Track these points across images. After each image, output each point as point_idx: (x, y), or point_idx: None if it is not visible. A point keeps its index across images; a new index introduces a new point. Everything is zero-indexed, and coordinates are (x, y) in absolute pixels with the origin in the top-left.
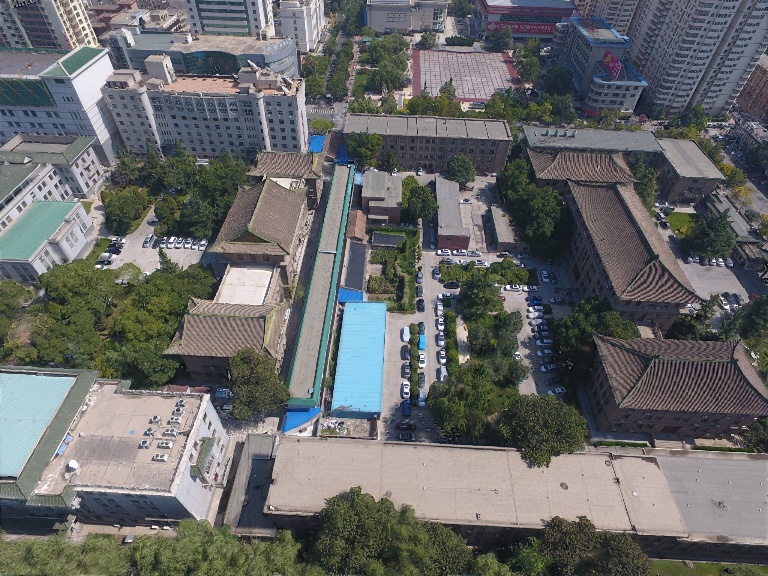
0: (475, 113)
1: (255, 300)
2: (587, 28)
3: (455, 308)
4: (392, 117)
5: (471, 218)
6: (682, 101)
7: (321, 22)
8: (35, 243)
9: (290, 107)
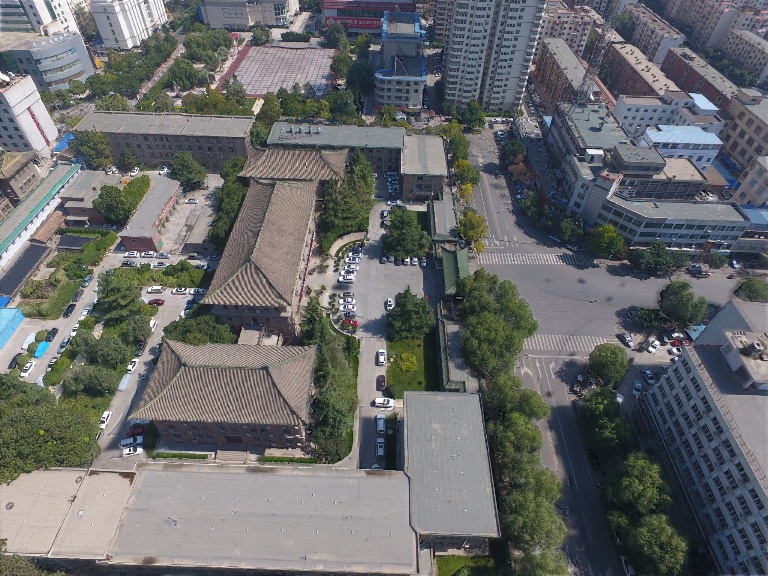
0: (239, 110)
1: None
2: (391, 22)
3: None
4: (137, 114)
5: (186, 218)
6: (470, 96)
7: (154, 18)
8: None
9: (1, 104)
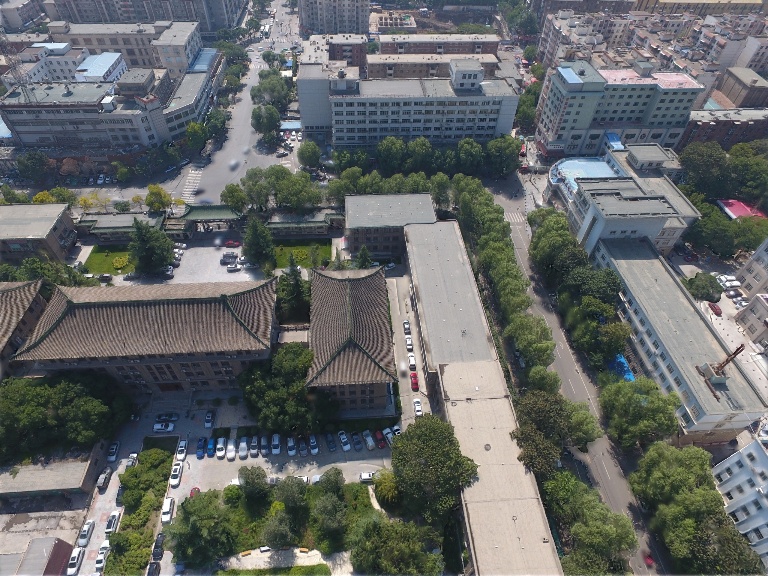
0: None
1: None
2: None
3: (204, 572)
4: None
5: None
6: None
7: None
8: None
9: None
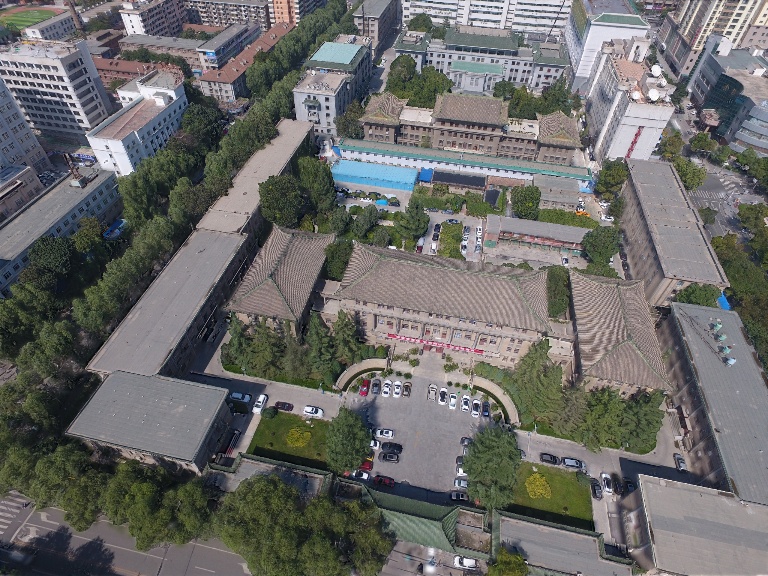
0: (760, 277)
1: (405, 119)
2: None
3: None
4: (681, 191)
5: (537, 260)
6: None
7: None
8: (464, 69)
9: None
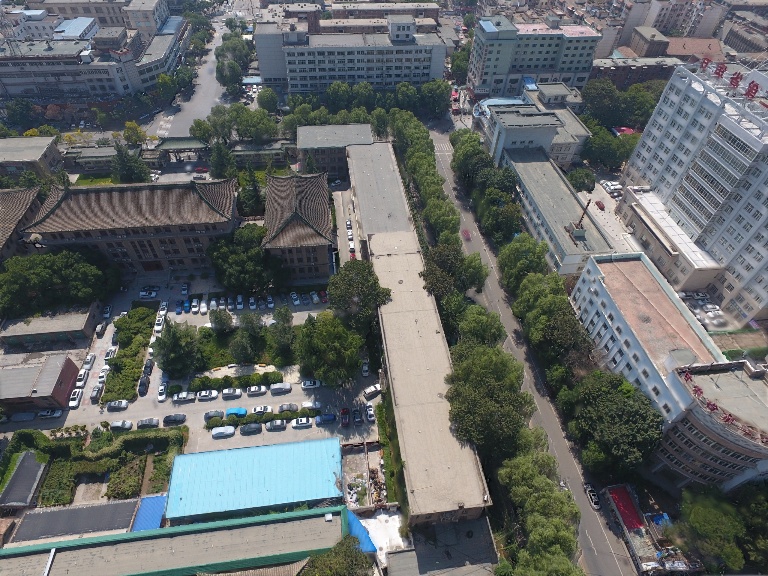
0: None
1: None
2: None
3: (184, 381)
4: None
5: (6, 367)
6: None
7: None
8: None
9: None
